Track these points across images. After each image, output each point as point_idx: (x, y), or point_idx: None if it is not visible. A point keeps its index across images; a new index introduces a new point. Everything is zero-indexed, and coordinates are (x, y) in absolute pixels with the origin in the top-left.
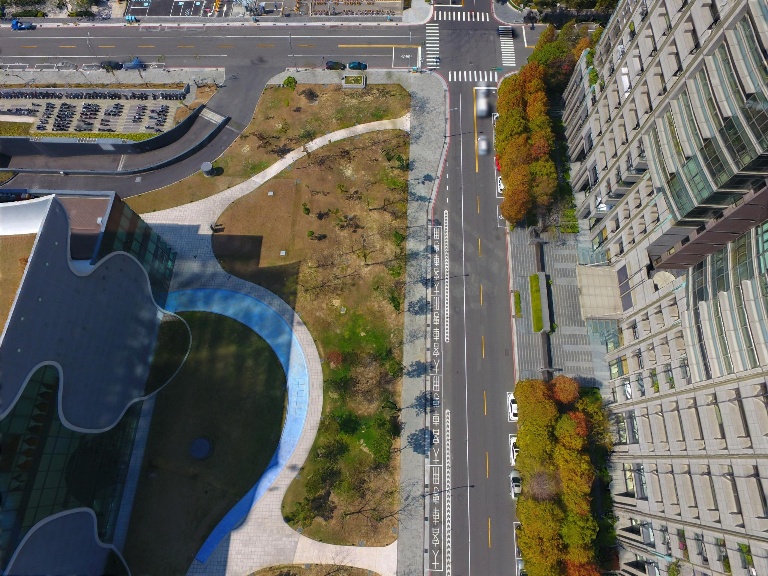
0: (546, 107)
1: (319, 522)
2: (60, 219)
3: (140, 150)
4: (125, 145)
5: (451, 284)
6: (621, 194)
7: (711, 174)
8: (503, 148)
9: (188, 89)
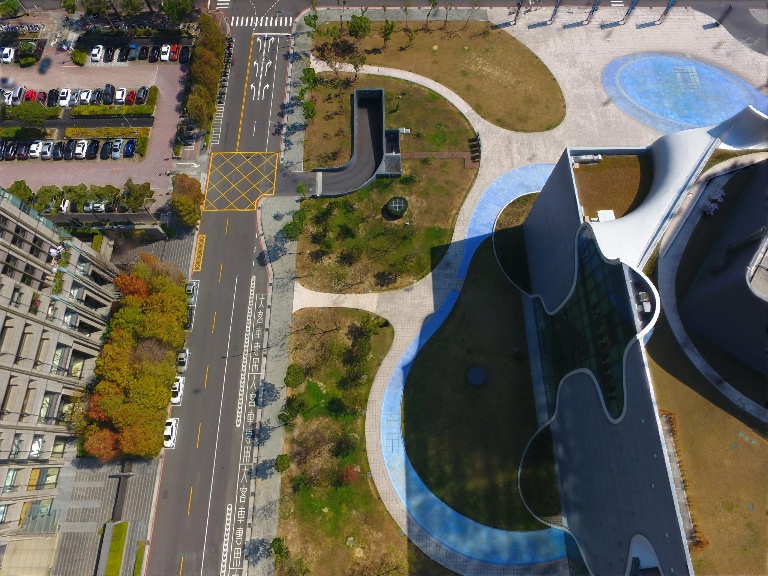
0: None
1: None
2: None
3: None
4: None
5: None
6: None
7: None
8: None
9: None
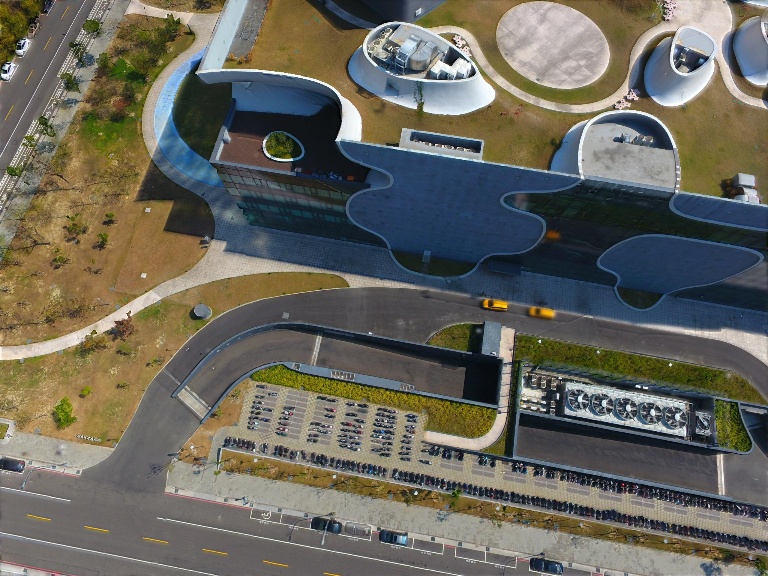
0: None
1: None
2: None
3: None
4: None
5: (8, 164)
6: None
7: None
8: None
9: None
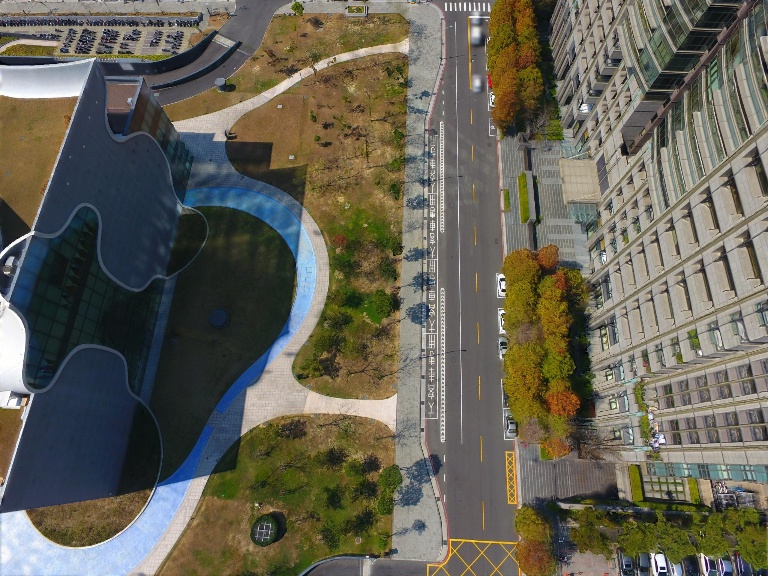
0: (534, 24)
1: (326, 380)
2: (99, 82)
3: (157, 70)
4: (144, 64)
5: (446, 184)
6: (600, 90)
7: (672, 38)
8: (494, 61)
9: (201, 17)
